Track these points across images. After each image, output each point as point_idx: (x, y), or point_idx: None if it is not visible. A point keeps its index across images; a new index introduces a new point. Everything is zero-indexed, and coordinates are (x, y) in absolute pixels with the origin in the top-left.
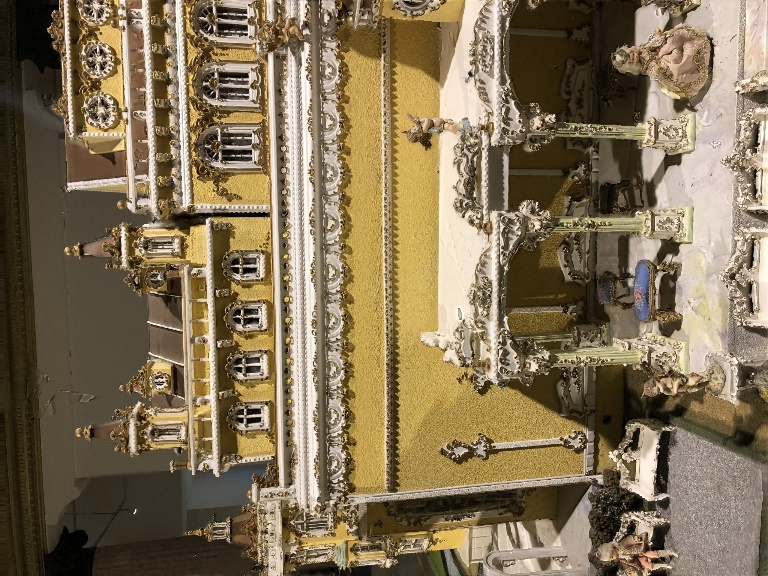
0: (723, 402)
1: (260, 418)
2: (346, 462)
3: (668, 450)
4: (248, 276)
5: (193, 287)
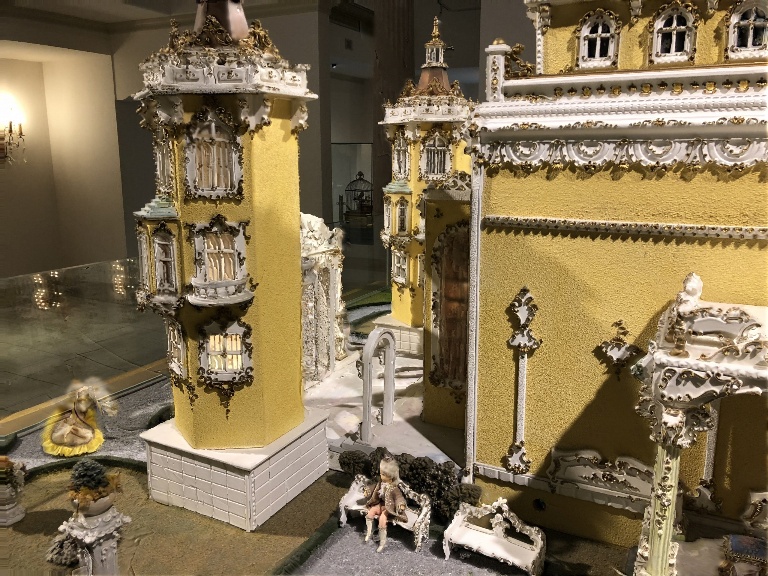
0: None
1: (594, 56)
2: (527, 165)
3: (502, 573)
4: None
5: None
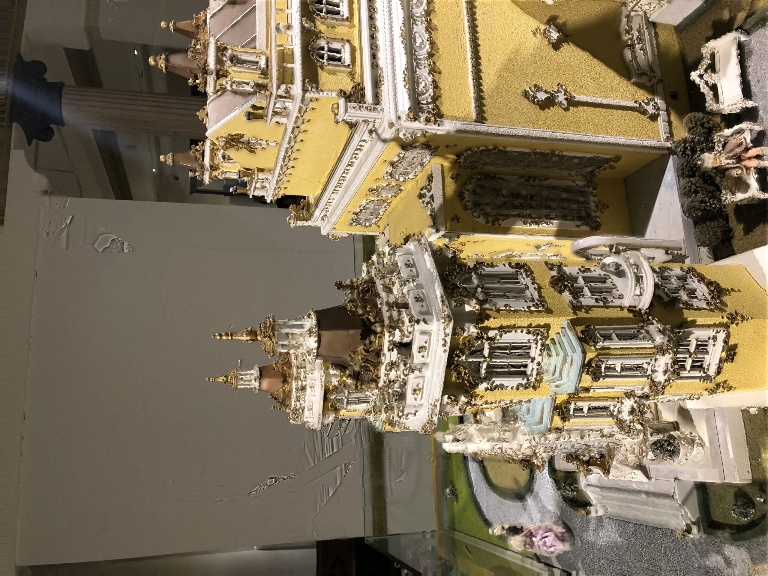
0: None
1: (340, 58)
2: (434, 83)
3: (746, 66)
4: None
5: None
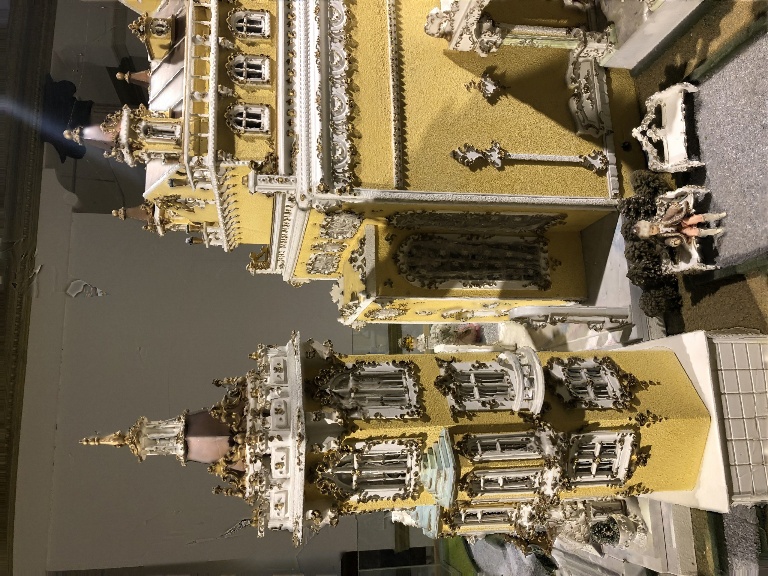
0: (740, 8)
1: (260, 124)
2: (351, 150)
3: (694, 121)
4: None
5: (197, 29)
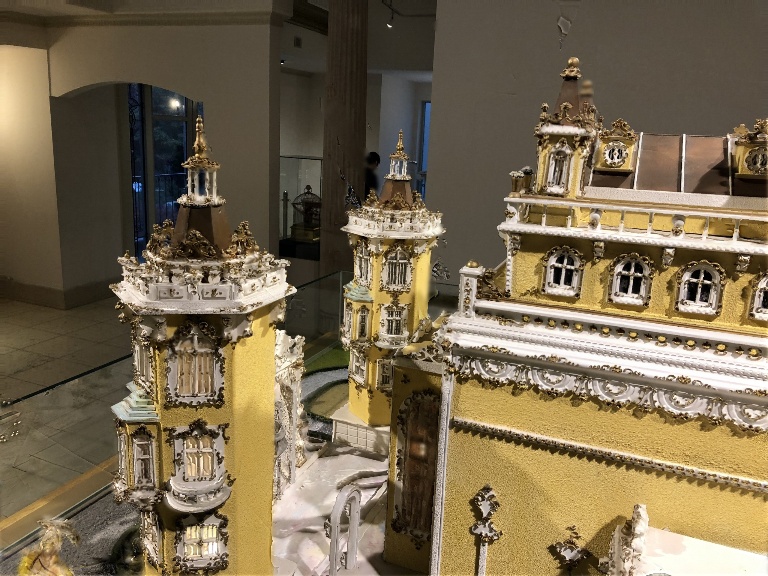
0: None
1: (559, 283)
2: (494, 382)
3: None
4: (760, 297)
5: None
